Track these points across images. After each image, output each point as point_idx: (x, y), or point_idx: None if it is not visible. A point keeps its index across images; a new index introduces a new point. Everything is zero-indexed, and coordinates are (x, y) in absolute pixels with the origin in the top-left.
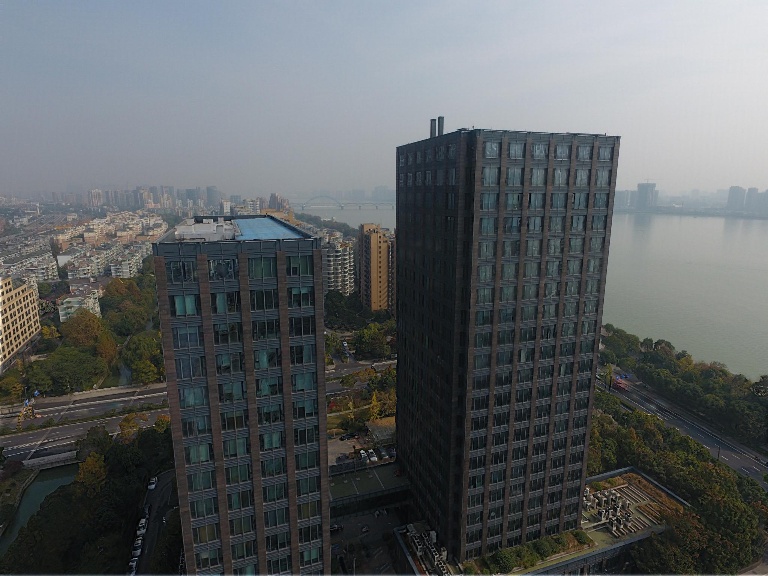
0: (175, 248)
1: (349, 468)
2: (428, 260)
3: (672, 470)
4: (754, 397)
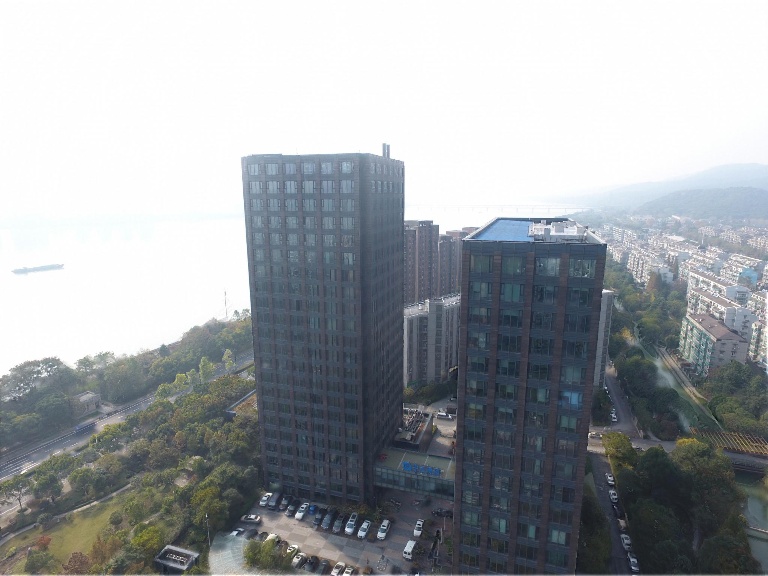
0: (560, 220)
1: (421, 470)
2: (392, 247)
3: (231, 390)
4: (32, 396)
